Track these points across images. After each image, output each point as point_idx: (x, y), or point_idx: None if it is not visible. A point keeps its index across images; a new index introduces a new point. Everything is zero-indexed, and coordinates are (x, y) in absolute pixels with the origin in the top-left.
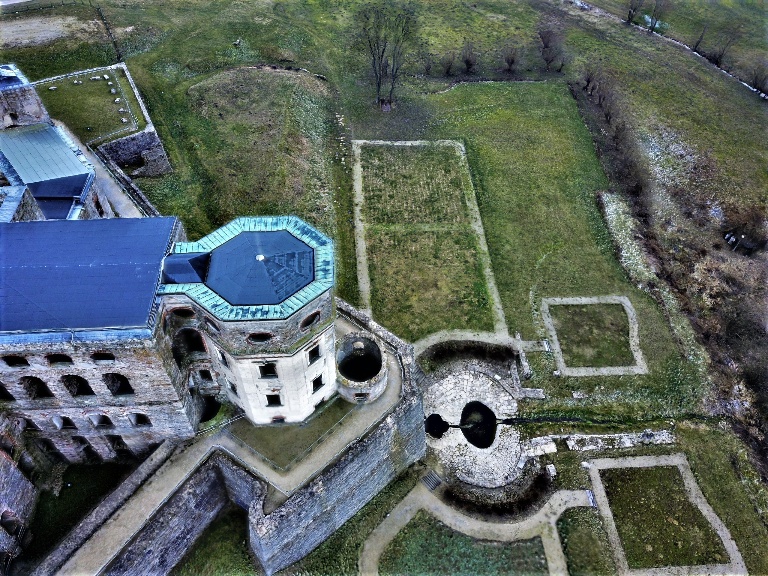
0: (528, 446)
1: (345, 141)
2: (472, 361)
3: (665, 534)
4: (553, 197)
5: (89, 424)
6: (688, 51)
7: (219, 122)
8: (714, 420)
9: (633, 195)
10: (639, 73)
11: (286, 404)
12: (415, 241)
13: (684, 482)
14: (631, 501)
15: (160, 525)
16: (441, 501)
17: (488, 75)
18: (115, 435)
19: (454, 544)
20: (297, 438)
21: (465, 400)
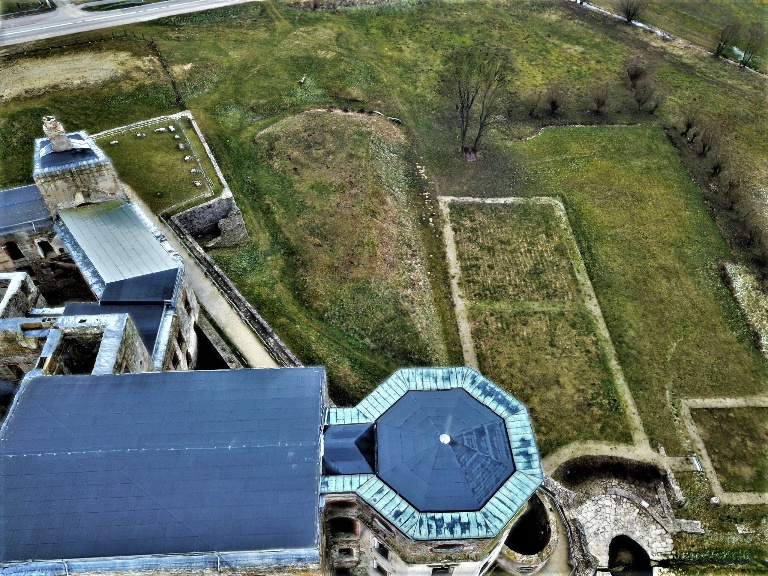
0: None
1: (431, 198)
2: (611, 481)
3: None
4: (673, 269)
5: None
6: None
7: (295, 178)
8: None
9: (759, 265)
10: (740, 116)
11: None
12: (525, 324)
13: None
14: None
15: None
16: None
17: (575, 117)
18: None
19: None
20: None
21: (610, 534)
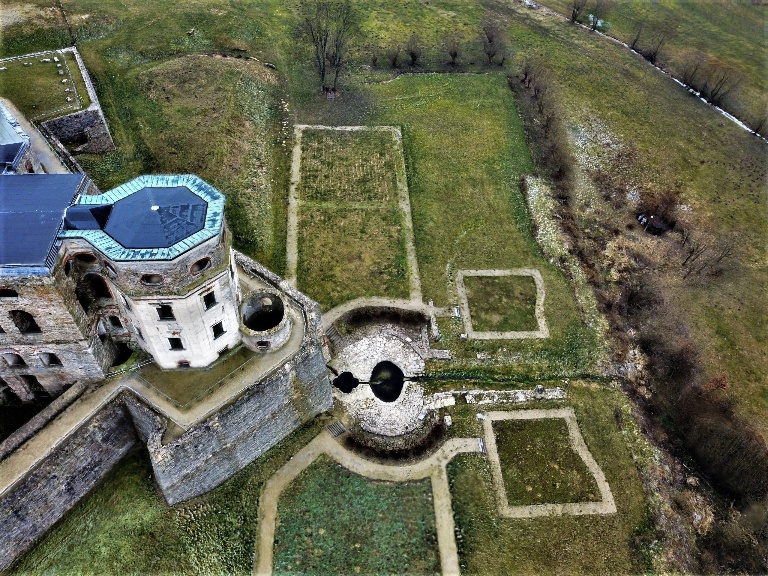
0: (430, 400)
1: (288, 125)
2: (387, 325)
3: (545, 476)
4: (480, 179)
5: (3, 363)
6: (626, 49)
7: (165, 105)
8: (606, 380)
9: (557, 179)
10: (576, 68)
11: (188, 348)
12: (344, 217)
13: (569, 432)
14: (518, 448)
15: (64, 453)
16: (342, 446)
17: (432, 67)
18: (30, 376)
19: (350, 483)
20: (201, 381)
21: (377, 360)
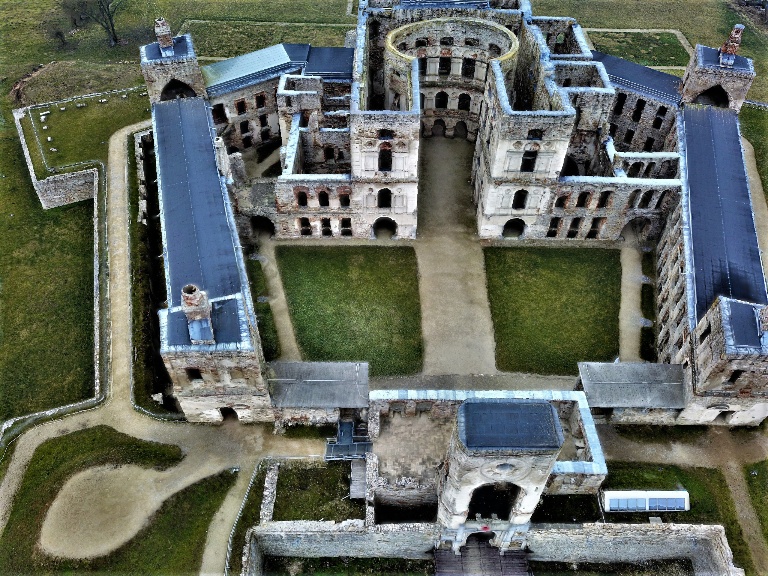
0: None
1: None
2: None
3: None
4: (264, 0)
5: None
6: None
7: None
8: None
9: None
10: None
11: None
12: None
13: None
14: None
15: None
16: None
17: None
18: None
19: None
20: None
21: None
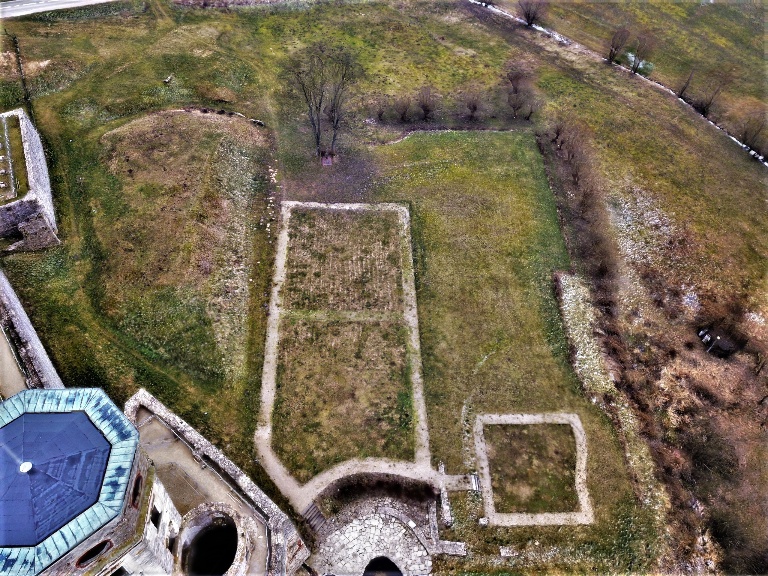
0: None
1: (274, 202)
2: (384, 500)
3: None
4: (503, 280)
5: None
6: (673, 97)
7: (126, 181)
8: None
9: (597, 277)
10: (616, 123)
11: None
12: (336, 335)
13: None
14: None
15: None
16: None
17: (447, 122)
18: None
19: None
20: None
21: (369, 555)
